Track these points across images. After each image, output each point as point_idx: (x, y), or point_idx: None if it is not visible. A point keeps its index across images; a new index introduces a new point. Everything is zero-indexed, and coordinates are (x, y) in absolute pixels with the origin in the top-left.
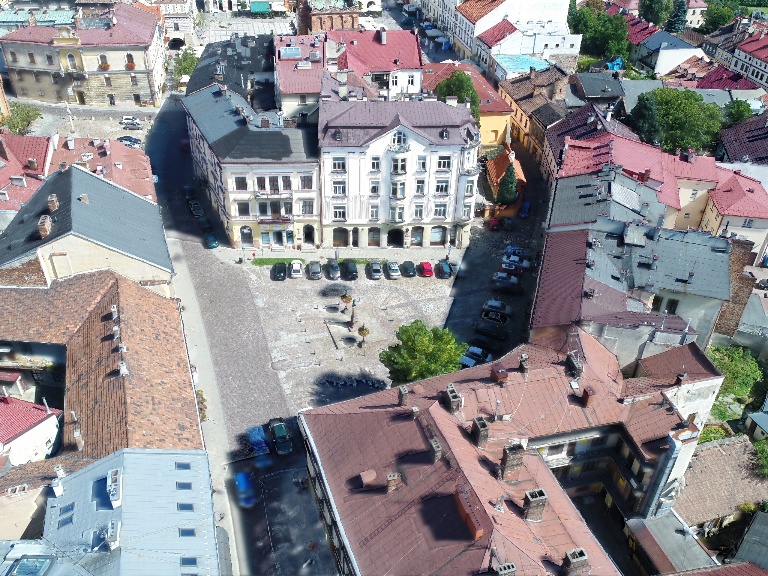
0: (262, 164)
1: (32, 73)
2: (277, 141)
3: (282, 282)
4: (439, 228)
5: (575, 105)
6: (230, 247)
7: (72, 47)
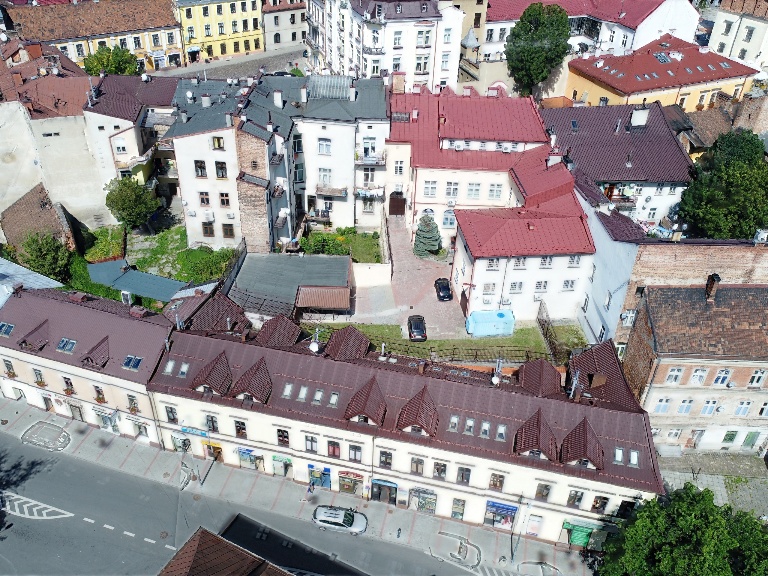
0: None
1: None
2: None
3: None
4: None
5: None
6: None
7: None
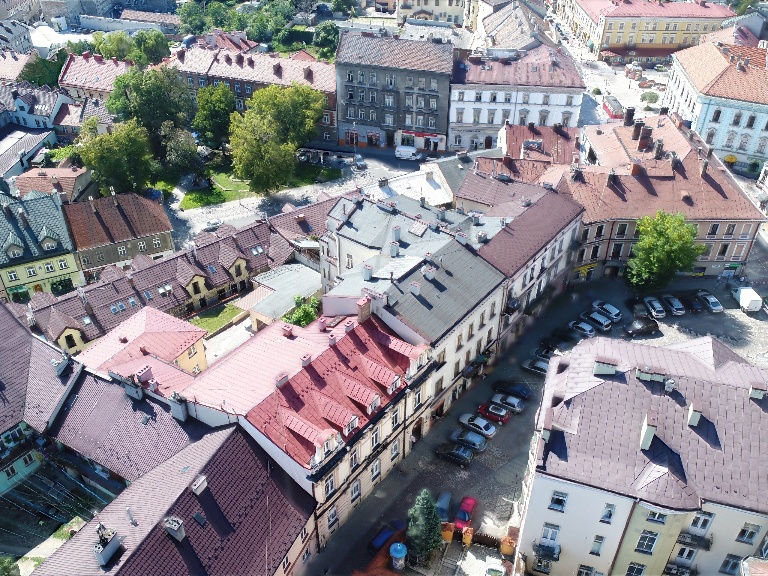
0: None
1: None
2: None
3: None
4: None
5: None
6: None
7: None
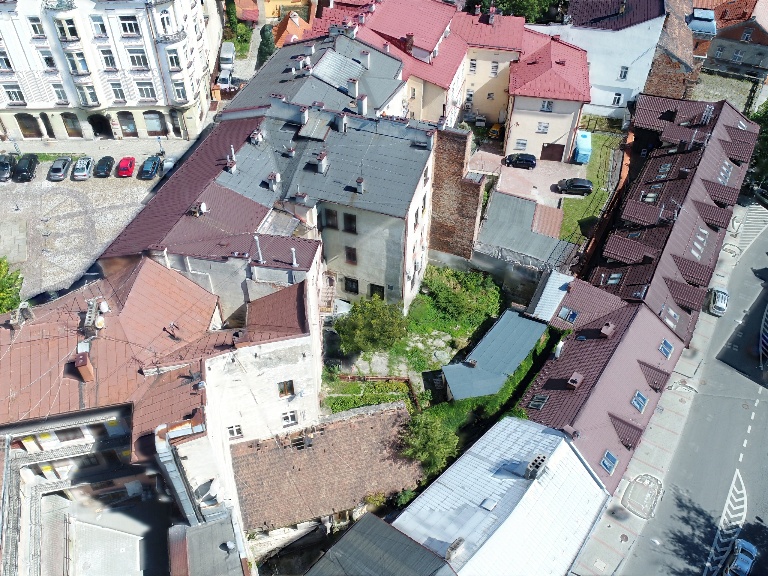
0: None
1: None
2: None
3: None
4: (154, 113)
5: None
6: None
7: None
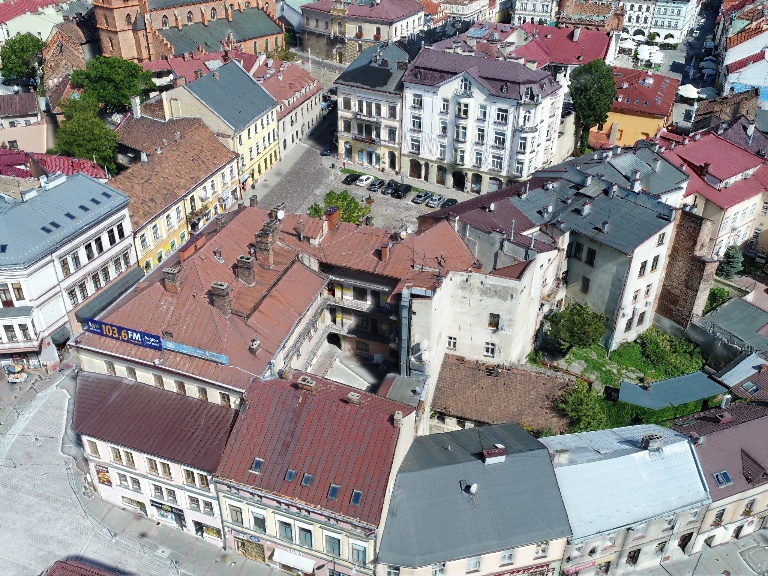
0: (360, 88)
1: (315, 34)
2: (382, 75)
3: (347, 185)
4: (496, 180)
5: (761, 130)
6: (337, 158)
7: (341, 16)
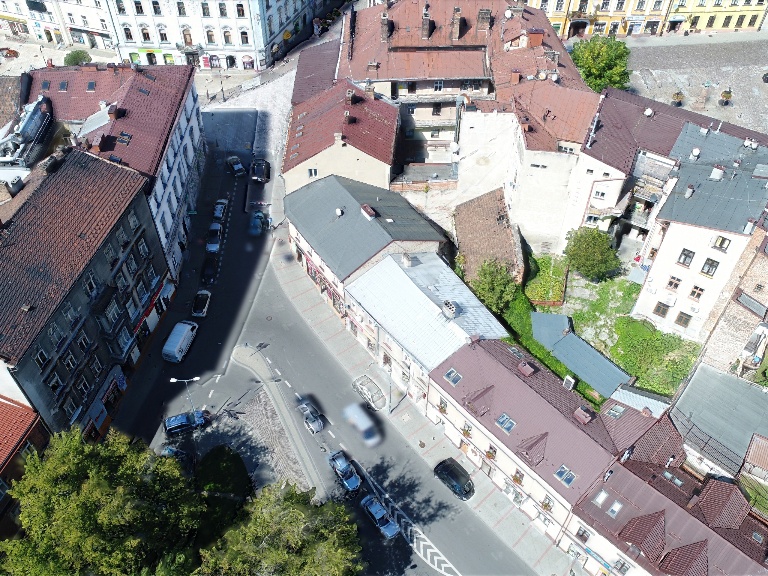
0: None
1: None
2: None
3: (762, 81)
4: None
5: None
6: None
7: None
